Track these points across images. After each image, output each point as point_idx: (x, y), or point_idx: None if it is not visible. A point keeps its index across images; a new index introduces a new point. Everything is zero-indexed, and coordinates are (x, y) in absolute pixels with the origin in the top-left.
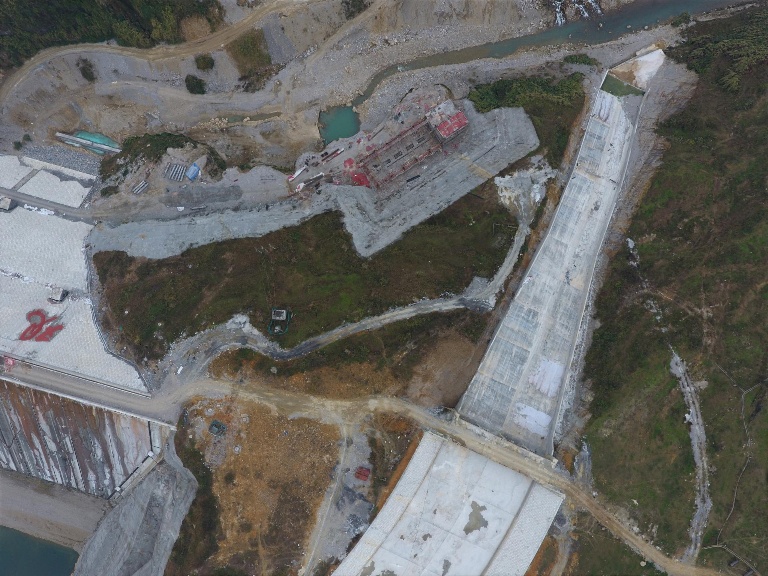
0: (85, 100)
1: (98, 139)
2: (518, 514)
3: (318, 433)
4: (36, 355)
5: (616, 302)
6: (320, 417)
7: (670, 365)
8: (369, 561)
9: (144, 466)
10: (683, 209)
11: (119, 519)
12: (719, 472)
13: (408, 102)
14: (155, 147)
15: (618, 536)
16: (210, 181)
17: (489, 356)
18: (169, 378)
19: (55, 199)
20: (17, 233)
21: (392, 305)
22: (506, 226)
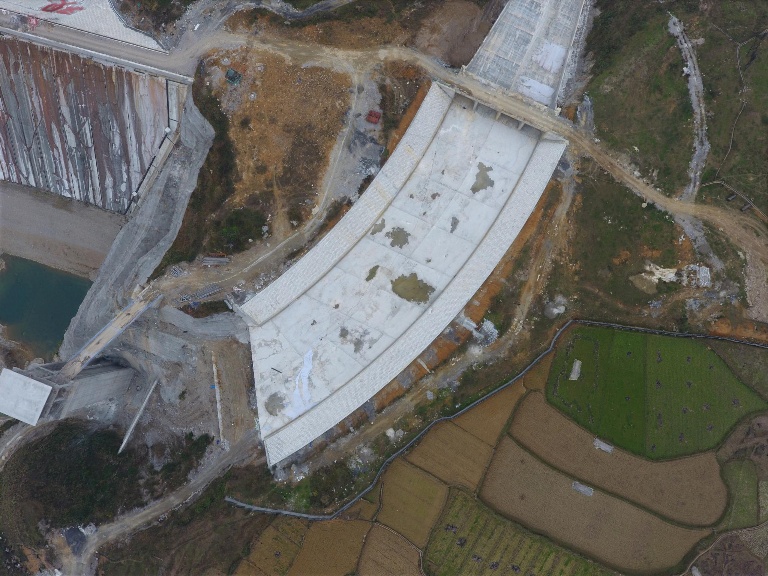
0: None
1: None
2: (523, 172)
3: (330, 80)
4: (58, 20)
5: None
6: (332, 66)
7: (668, 25)
8: (380, 218)
9: (161, 154)
10: None
11: (136, 220)
12: (716, 117)
13: None
14: None
15: (620, 180)
16: None
17: (494, 36)
18: (186, 34)
19: None
20: None
21: None
22: None
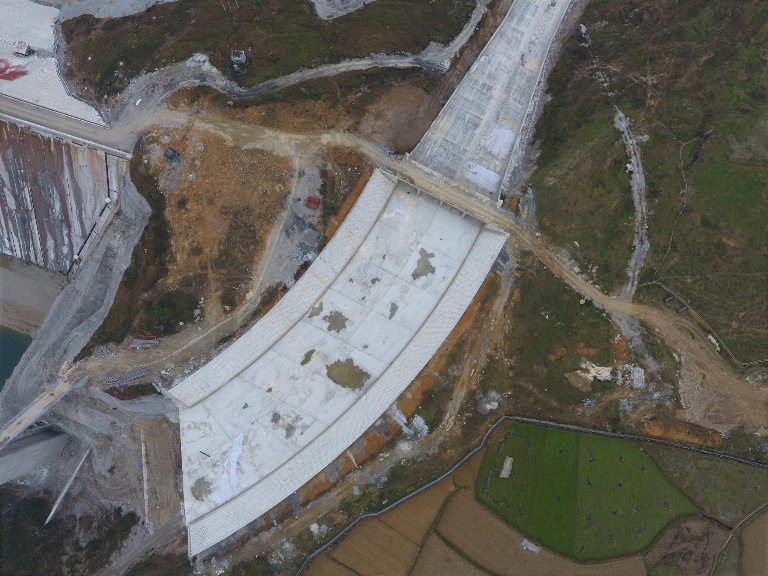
0: None
1: None
2: (465, 260)
3: (271, 163)
4: None
5: (567, 76)
6: (273, 149)
7: (614, 120)
8: (318, 302)
9: (102, 221)
10: (634, 1)
11: (75, 284)
12: (657, 216)
13: None
14: None
15: (559, 275)
16: None
17: (443, 119)
18: (127, 109)
19: None
20: None
21: (349, 56)
22: (464, 3)
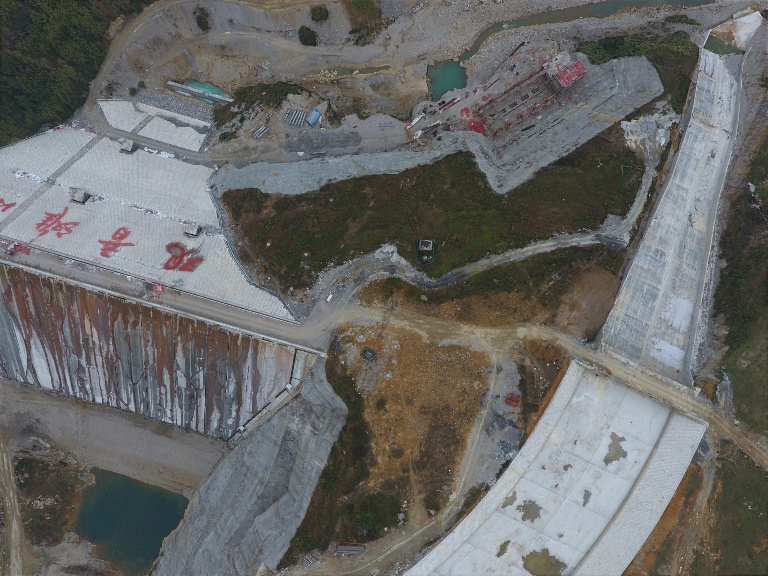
0: (198, 49)
1: (208, 89)
2: (657, 445)
3: (468, 360)
4: (183, 283)
5: (742, 242)
6: (470, 344)
7: None
8: (511, 491)
9: (276, 401)
10: None
11: (244, 458)
12: None
13: (523, 54)
14: (274, 93)
15: (760, 464)
16: (330, 127)
17: (622, 292)
18: (319, 305)
19: (174, 143)
20: (143, 173)
21: (533, 238)
22: (634, 168)
